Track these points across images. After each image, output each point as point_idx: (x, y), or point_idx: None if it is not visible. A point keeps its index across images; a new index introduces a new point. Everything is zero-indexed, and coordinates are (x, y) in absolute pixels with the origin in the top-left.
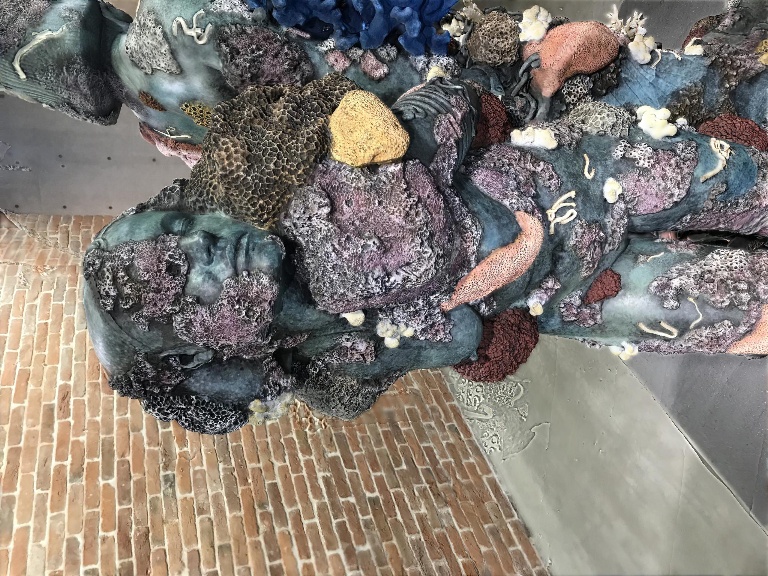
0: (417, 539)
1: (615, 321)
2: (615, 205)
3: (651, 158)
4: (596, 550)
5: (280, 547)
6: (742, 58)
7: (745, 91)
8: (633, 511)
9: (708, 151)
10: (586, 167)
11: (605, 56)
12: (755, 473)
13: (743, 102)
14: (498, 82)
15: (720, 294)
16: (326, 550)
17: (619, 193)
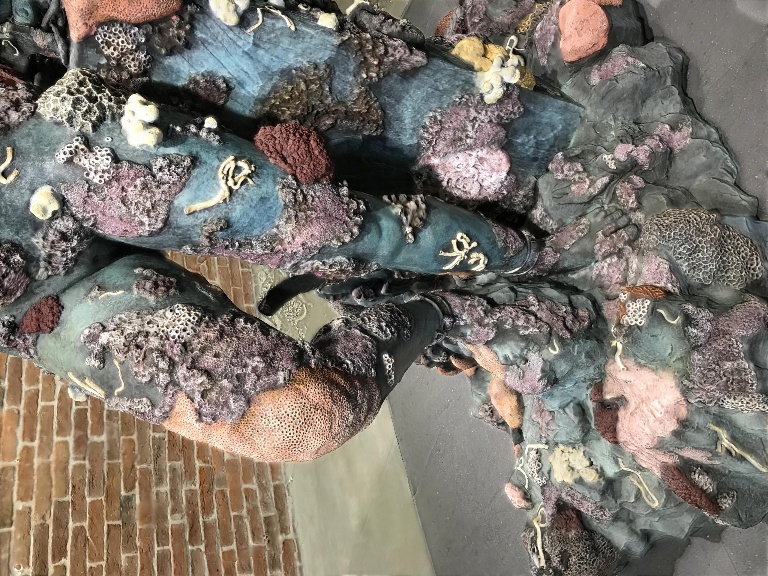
0: (160, 438)
1: (49, 361)
2: (54, 222)
3: (106, 171)
4: (323, 481)
5: (4, 425)
6: (393, 44)
7: (396, 86)
8: (355, 457)
9: (210, 174)
10: (2, 166)
11: (149, 5)
12: (425, 463)
13: (393, 99)
14: (24, 1)
15: (145, 366)
16: (55, 436)
17: (53, 209)
